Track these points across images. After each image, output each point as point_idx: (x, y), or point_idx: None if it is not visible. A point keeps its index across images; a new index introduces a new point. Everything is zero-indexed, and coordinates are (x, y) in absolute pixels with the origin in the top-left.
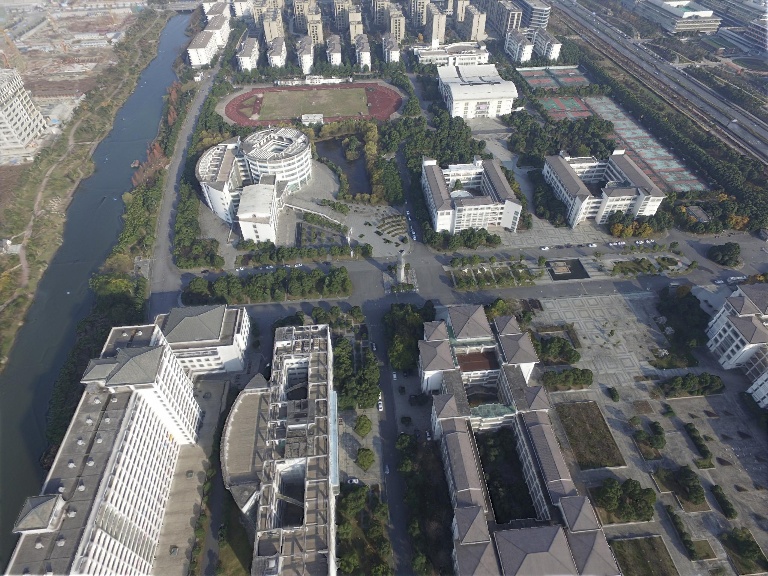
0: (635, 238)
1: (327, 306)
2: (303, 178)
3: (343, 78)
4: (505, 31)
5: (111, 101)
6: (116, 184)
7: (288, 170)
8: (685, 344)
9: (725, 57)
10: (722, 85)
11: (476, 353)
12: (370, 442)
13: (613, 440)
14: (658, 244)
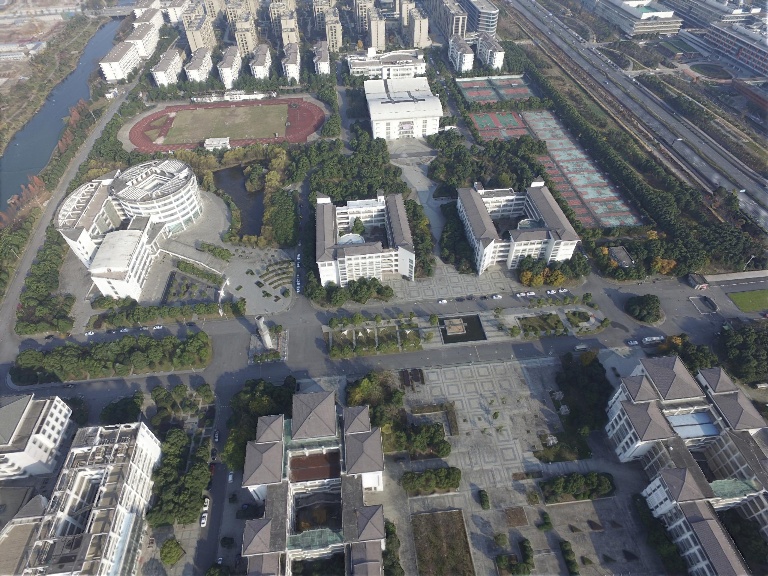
0: (547, 286)
1: (177, 381)
2: (187, 217)
3: (265, 93)
4: None
5: (9, 123)
6: None
7: (165, 210)
8: (576, 431)
9: (683, 63)
10: (674, 96)
11: (318, 455)
12: (179, 572)
13: (471, 565)
14: (572, 294)
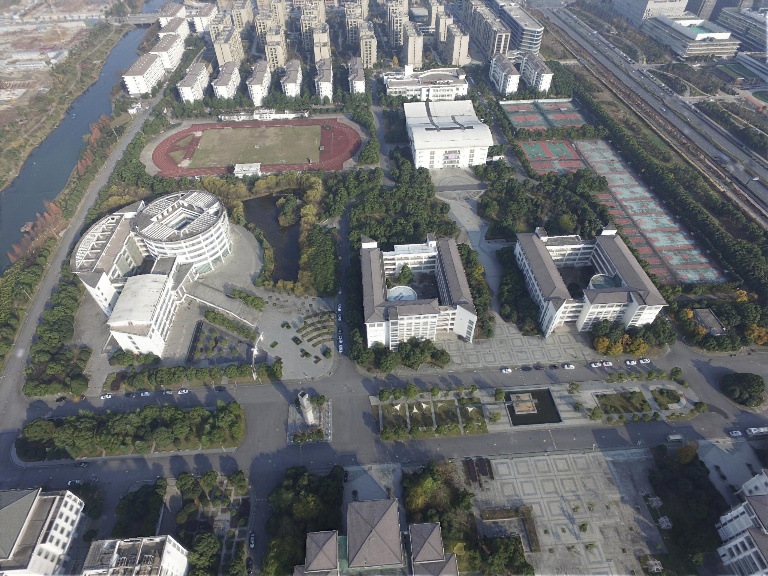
0: (626, 355)
1: (205, 463)
2: (216, 257)
3: (297, 113)
4: (491, 54)
5: (26, 139)
6: None
7: (192, 251)
8: (686, 557)
9: (744, 89)
10: (740, 127)
11: None
12: None
13: None
14: (655, 366)
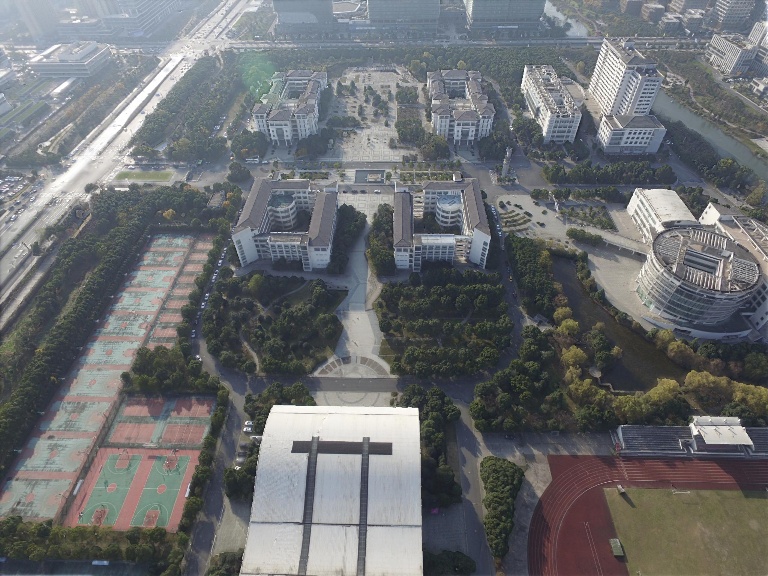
0: None
1: None
2: None
3: None
4: None
5: None
6: None
7: None
8: None
9: None
10: None
11: None
12: (514, 118)
13: None
14: None
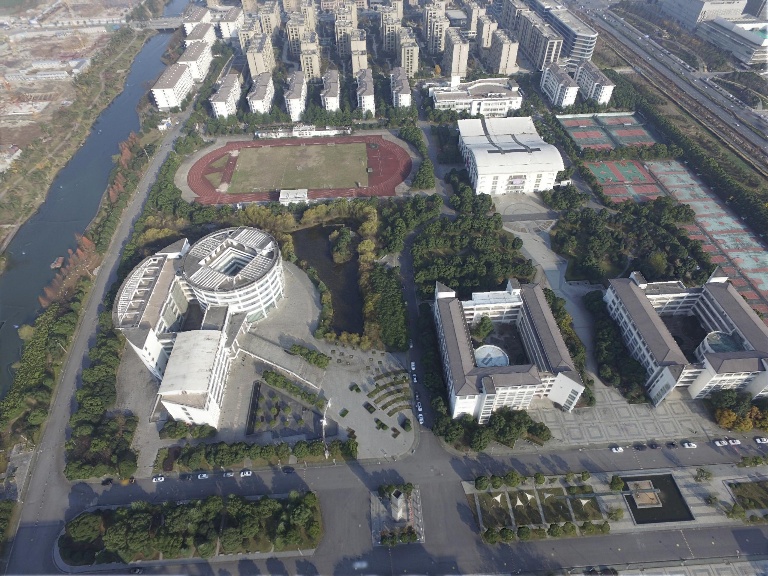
0: (753, 430)
1: (280, 570)
2: (270, 303)
3: (339, 129)
4: (541, 62)
5: (52, 159)
6: (25, 297)
7: (246, 299)
8: None
9: None
10: None
11: None
12: None
13: None
14: None
